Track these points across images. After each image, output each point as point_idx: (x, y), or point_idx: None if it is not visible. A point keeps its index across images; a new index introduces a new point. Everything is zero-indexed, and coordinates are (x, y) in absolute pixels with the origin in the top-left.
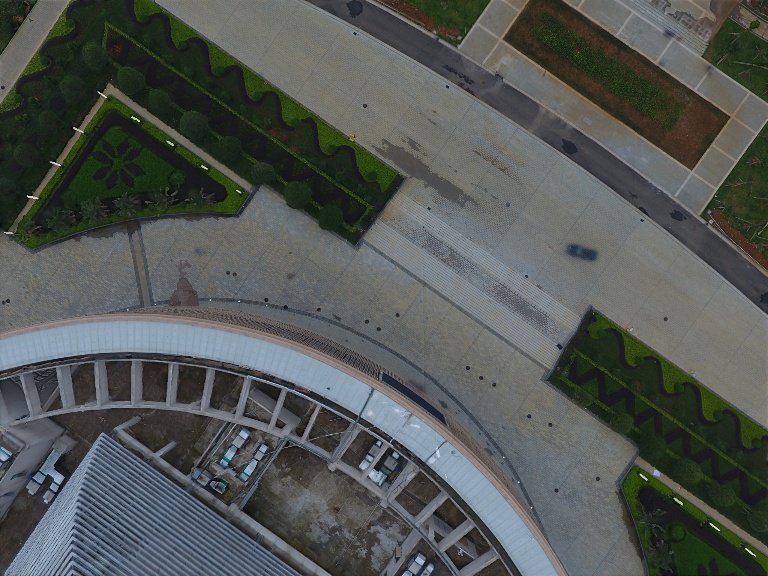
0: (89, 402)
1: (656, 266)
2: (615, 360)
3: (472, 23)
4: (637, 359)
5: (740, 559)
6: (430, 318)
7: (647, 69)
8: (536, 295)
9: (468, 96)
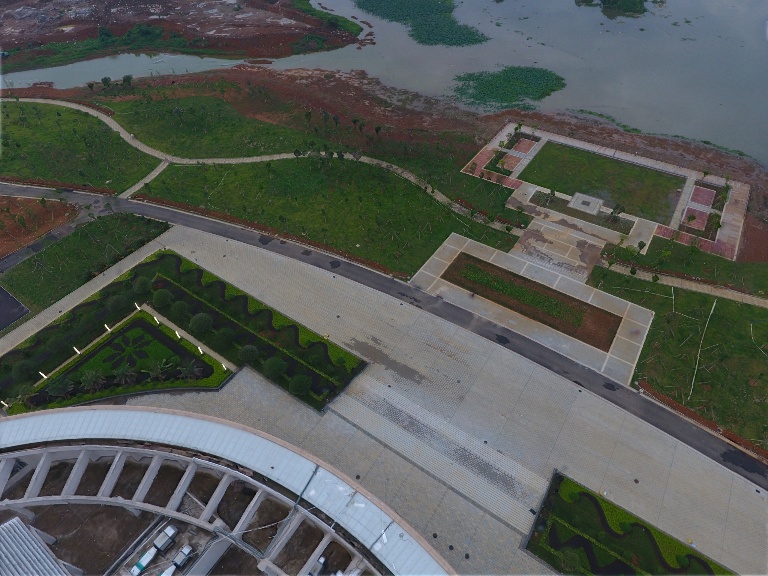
0: None
1: (607, 429)
2: (598, 526)
3: (417, 270)
4: (621, 524)
5: None
6: (391, 479)
7: (548, 291)
8: (498, 458)
9: (418, 309)
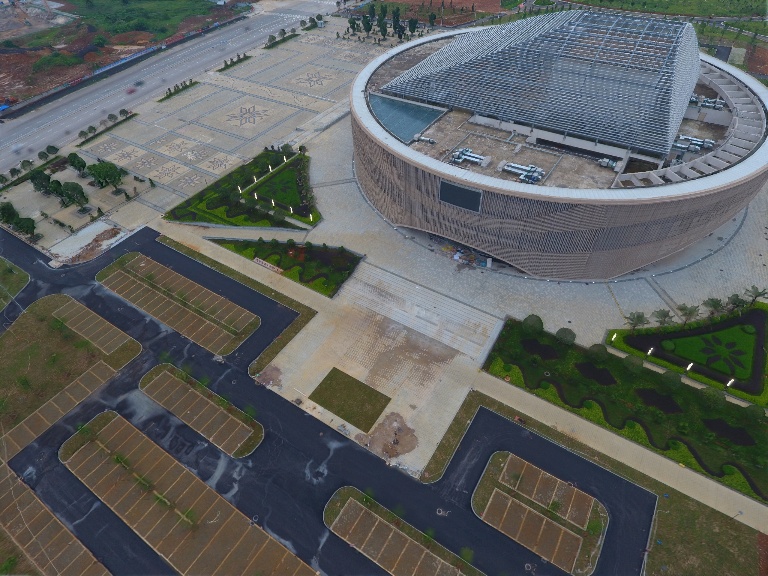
0: None
1: None
2: None
3: None
4: None
5: (758, 374)
6: None
7: None
8: None
9: None
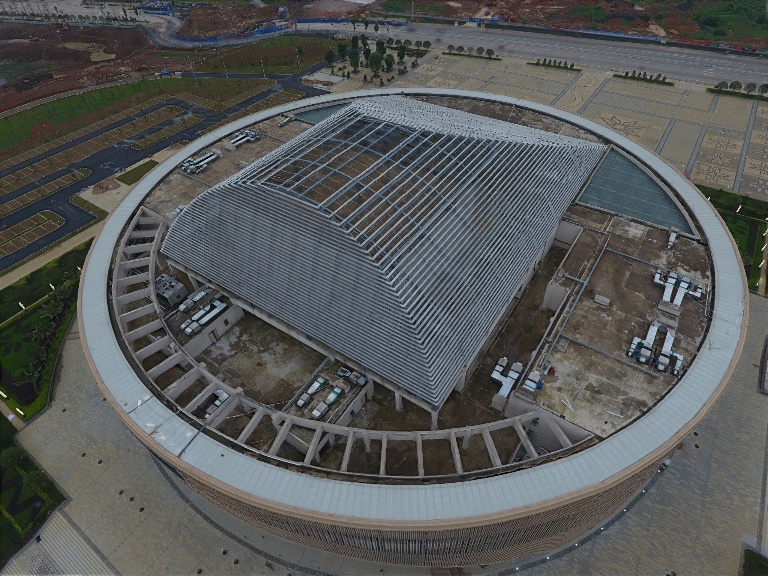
0: None
1: None
2: None
3: None
4: None
5: None
6: (163, 569)
7: None
8: None
9: None
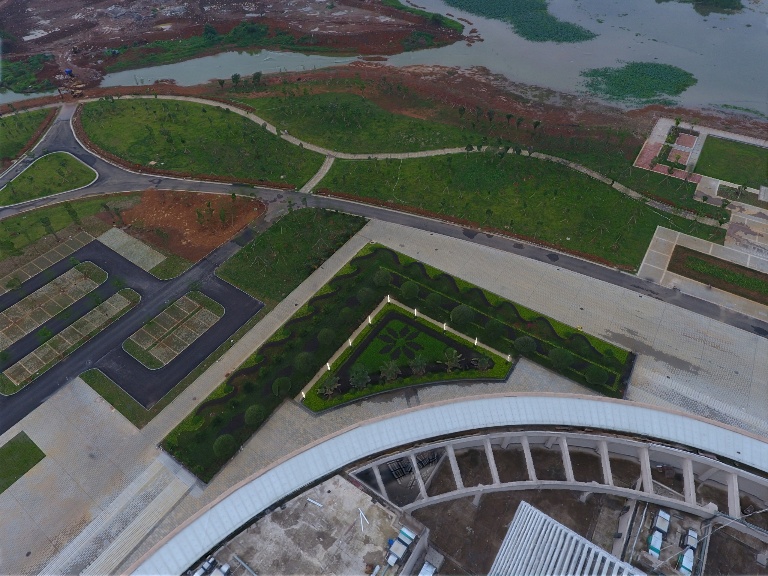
0: (452, 509)
1: None
2: None
3: (640, 263)
4: None
5: None
6: None
7: None
8: None
9: (659, 301)
